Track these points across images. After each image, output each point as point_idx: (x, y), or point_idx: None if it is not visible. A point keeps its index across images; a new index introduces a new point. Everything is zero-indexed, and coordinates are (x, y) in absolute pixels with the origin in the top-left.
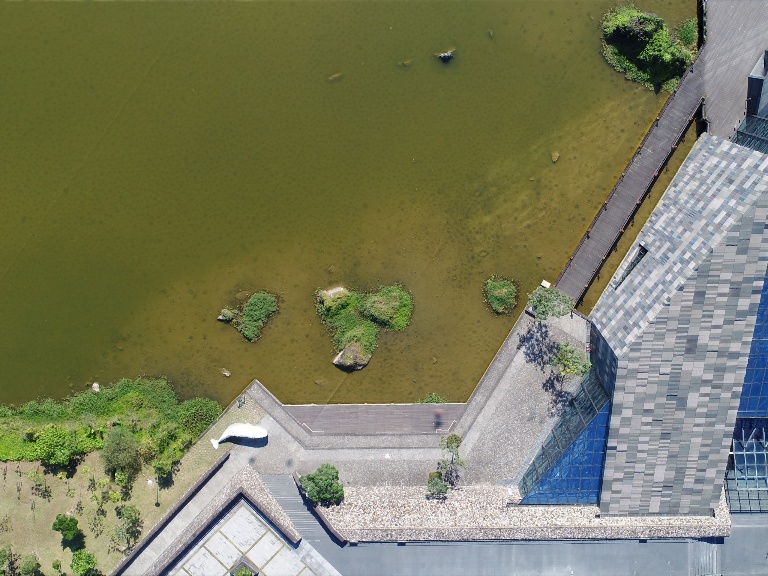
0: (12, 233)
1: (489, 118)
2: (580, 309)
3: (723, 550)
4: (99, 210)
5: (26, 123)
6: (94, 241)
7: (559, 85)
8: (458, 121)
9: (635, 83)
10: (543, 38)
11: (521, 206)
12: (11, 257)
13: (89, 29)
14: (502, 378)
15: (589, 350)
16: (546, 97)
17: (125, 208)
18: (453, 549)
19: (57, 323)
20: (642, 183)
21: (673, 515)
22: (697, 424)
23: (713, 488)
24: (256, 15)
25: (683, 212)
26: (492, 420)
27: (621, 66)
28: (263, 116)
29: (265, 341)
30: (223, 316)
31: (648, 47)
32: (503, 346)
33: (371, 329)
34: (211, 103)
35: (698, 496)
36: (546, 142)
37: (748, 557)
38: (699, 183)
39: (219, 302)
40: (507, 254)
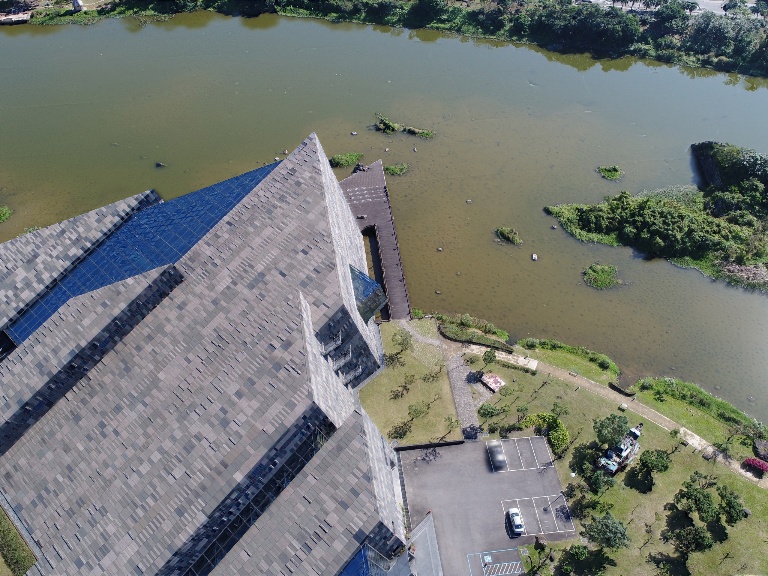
0: None
1: None
2: None
3: None
4: None
5: None
6: None
7: None
8: None
9: None
10: (202, 185)
11: None
12: None
13: None
14: None
15: None
16: None
17: None
18: None
19: None
20: None
21: None
22: None
23: None
24: (124, 115)
25: None
26: None
27: None
28: (75, 137)
29: None
30: None
31: None
32: None
33: None
34: (68, 123)
35: None
36: None
37: None
38: None
39: None
40: None
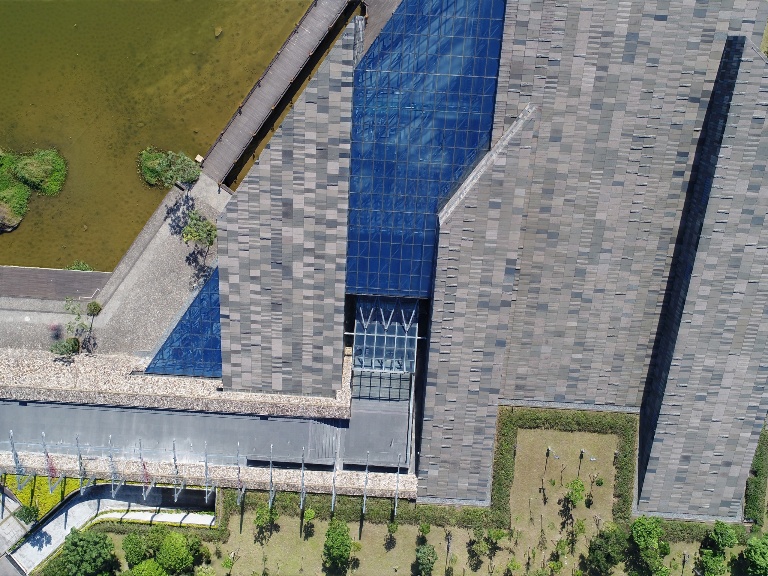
0: None
1: None
2: (233, 187)
3: (347, 434)
4: None
5: None
6: None
7: None
8: None
9: None
10: None
11: (181, 79)
12: None
13: None
14: (146, 249)
15: None
16: None
17: None
18: (74, 412)
19: None
20: (297, 62)
21: (296, 394)
22: (306, 296)
23: (333, 368)
24: None
25: None
26: (133, 290)
27: None
28: None
29: None
30: None
31: None
32: (150, 217)
33: (23, 192)
34: None
35: (319, 375)
36: (210, 17)
37: (372, 443)
38: None
39: None
40: (164, 126)
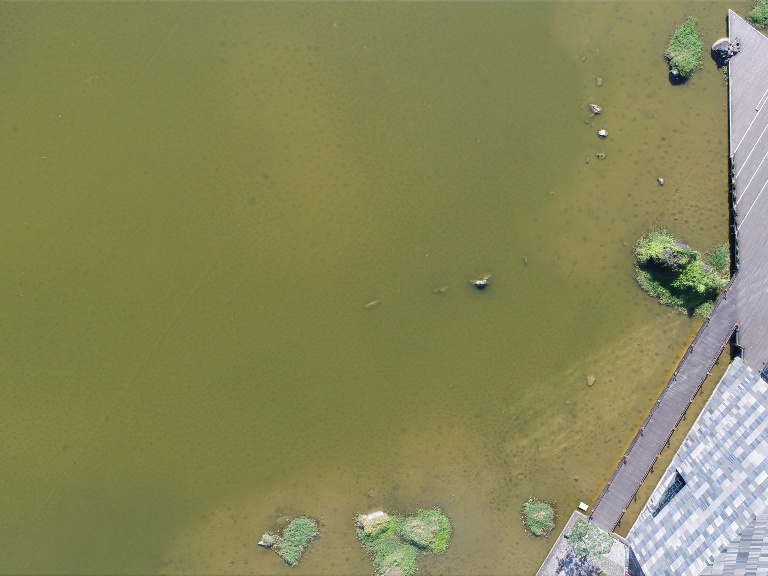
0: (54, 461)
1: (525, 343)
2: (618, 530)
3: None
4: (140, 437)
5: (67, 353)
6: (135, 468)
7: (593, 309)
8: (494, 346)
9: (669, 307)
10: (577, 264)
11: (558, 429)
12: (53, 485)
13: (128, 260)
14: None
15: (628, 574)
16: (581, 321)
17: (166, 435)
18: None
19: (99, 549)
20: (678, 409)
21: None
22: None
23: None
24: (293, 244)
25: (721, 451)
26: None
27: (655, 291)
28: (301, 343)
29: (306, 565)
30: (264, 542)
31: (682, 277)
32: (542, 570)
33: (411, 553)
34: (250, 331)
35: None
36: (581, 366)
37: None
38: (736, 422)
39: (260, 527)
40: (544, 476)
